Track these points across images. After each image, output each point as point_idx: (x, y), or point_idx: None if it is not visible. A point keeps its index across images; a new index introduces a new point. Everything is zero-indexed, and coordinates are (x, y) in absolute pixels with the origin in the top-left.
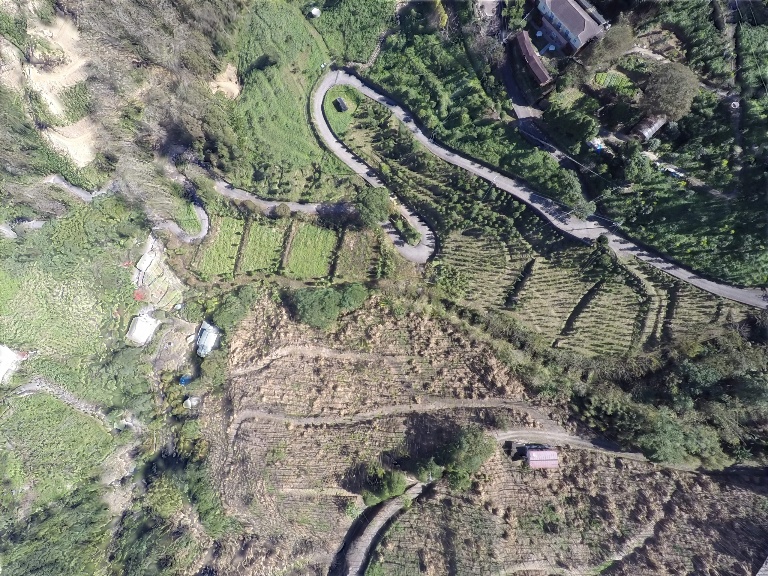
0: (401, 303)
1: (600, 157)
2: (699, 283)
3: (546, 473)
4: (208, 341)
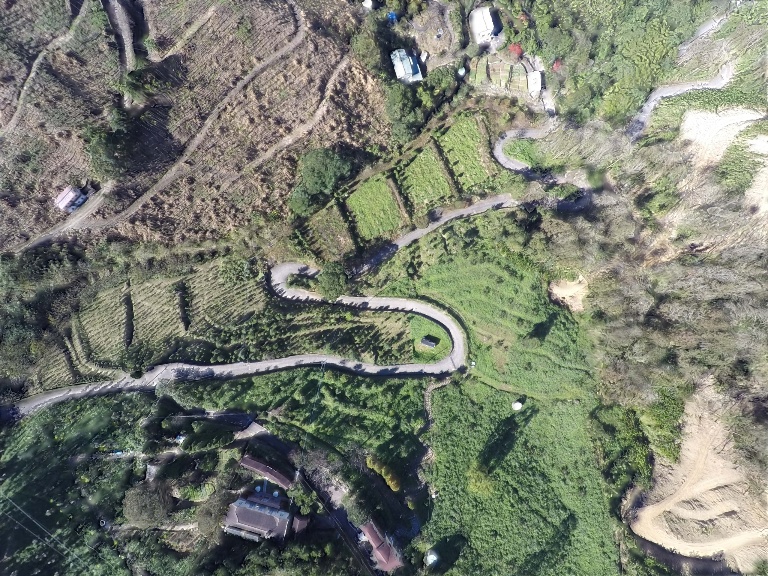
0: (260, 225)
1: (173, 431)
2: (62, 391)
3: (60, 189)
4: (401, 67)
